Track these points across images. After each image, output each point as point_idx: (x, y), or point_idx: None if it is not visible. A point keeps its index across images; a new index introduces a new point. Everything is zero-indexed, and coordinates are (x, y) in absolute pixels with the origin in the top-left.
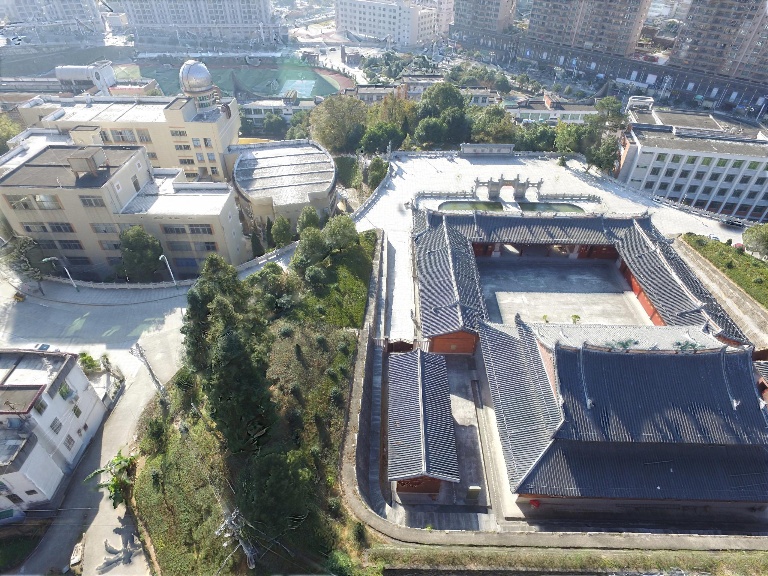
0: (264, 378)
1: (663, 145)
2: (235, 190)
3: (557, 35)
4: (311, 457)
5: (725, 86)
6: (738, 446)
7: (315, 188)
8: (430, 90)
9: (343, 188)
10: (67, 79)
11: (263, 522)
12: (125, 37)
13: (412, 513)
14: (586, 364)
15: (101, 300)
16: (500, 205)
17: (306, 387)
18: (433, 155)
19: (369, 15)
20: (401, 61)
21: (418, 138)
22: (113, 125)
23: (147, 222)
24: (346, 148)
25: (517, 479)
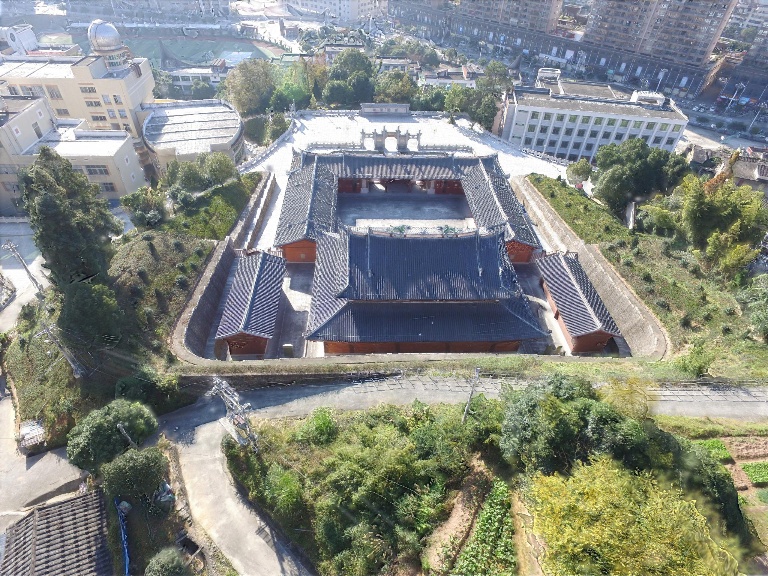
0: (92, 243)
1: (537, 104)
2: (143, 143)
3: (486, 11)
4: (145, 316)
5: (631, 61)
6: (486, 305)
7: (219, 141)
8: (340, 56)
9: (254, 145)
10: None
11: (72, 329)
12: (56, 5)
13: None
14: (372, 246)
15: (1, 232)
16: None
17: (154, 273)
18: (336, 114)
19: None
20: (338, 35)
21: (325, 99)
22: (22, 81)
23: None
24: (261, 110)
25: (311, 330)
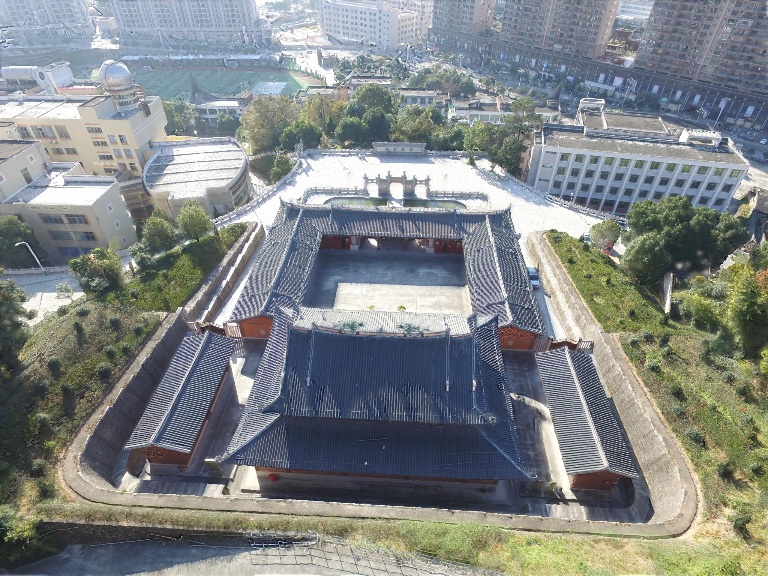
0: None
1: (568, 145)
2: None
3: (528, 38)
4: (37, 423)
5: (688, 89)
6: (455, 427)
7: (218, 183)
8: (358, 90)
9: (261, 185)
10: (12, 79)
11: None
12: (110, 40)
13: (146, 481)
14: (316, 344)
15: None
16: (387, 201)
17: (72, 361)
18: (346, 153)
19: (351, 19)
20: (375, 64)
21: (337, 137)
22: (32, 122)
23: (26, 212)
24: (274, 146)
25: (231, 450)
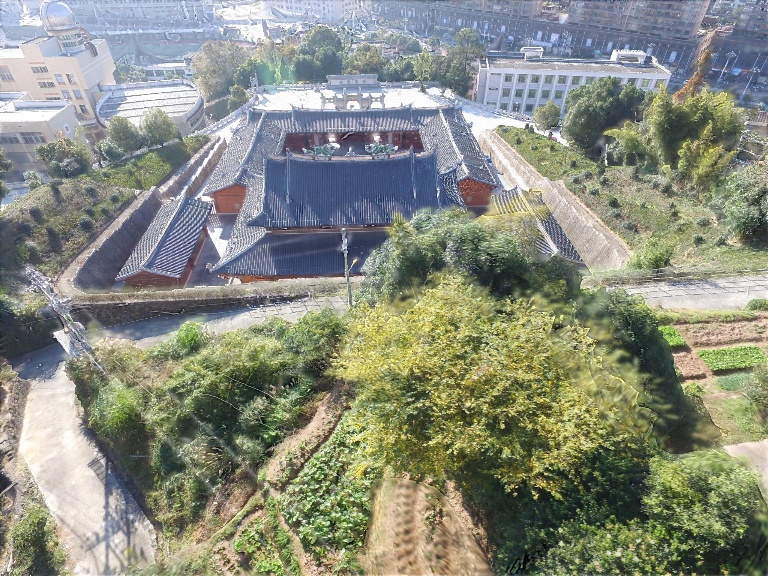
0: None
1: (510, 67)
2: None
3: (469, 1)
4: (27, 251)
5: (618, 39)
6: None
7: None
8: (308, 34)
9: None
10: None
11: None
12: None
13: None
14: (292, 171)
15: None
16: None
17: (52, 214)
18: (301, 88)
19: None
20: None
21: (291, 75)
22: None
23: None
24: (228, 91)
25: None
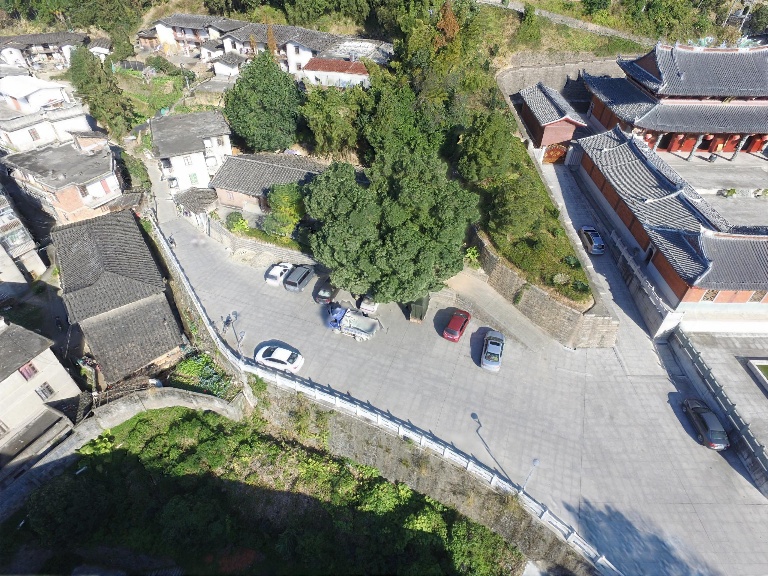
0: None
1: None
2: None
3: None
4: None
5: None
6: None
7: None
8: None
9: None
10: None
11: None
12: None
13: None
14: None
15: None
16: None
17: None
18: None
19: None
20: None
21: None
22: None
23: None
24: None
25: None
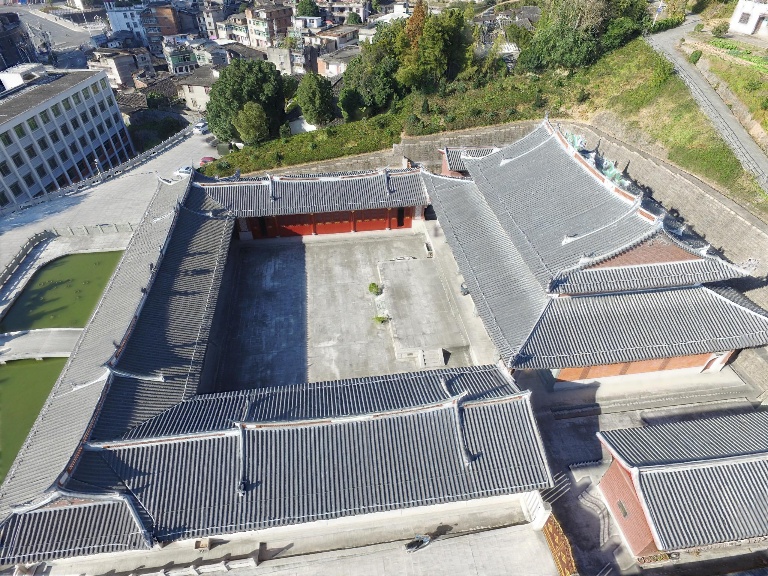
0: None
1: None
2: None
3: None
4: None
5: None
6: None
7: None
8: None
9: None
10: None
11: None
12: None
13: None
14: None
15: None
16: None
17: None
18: None
19: None
20: None
21: None
22: None
23: None
24: None
25: None
